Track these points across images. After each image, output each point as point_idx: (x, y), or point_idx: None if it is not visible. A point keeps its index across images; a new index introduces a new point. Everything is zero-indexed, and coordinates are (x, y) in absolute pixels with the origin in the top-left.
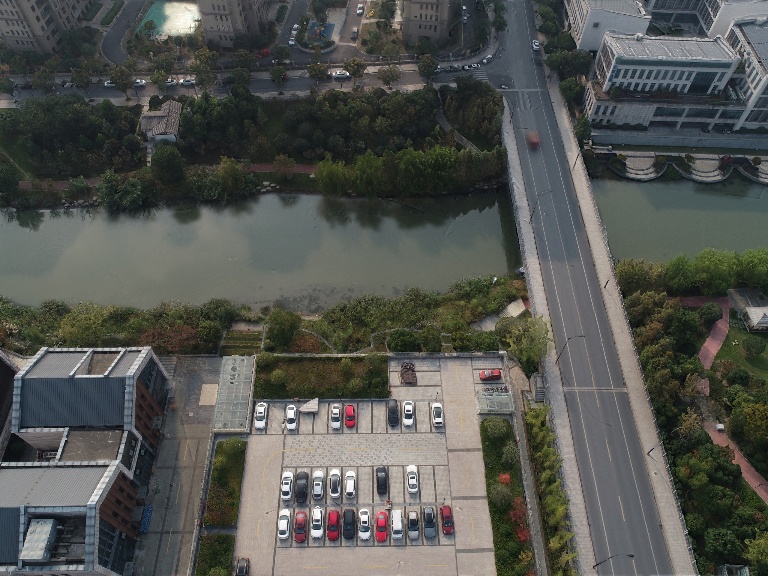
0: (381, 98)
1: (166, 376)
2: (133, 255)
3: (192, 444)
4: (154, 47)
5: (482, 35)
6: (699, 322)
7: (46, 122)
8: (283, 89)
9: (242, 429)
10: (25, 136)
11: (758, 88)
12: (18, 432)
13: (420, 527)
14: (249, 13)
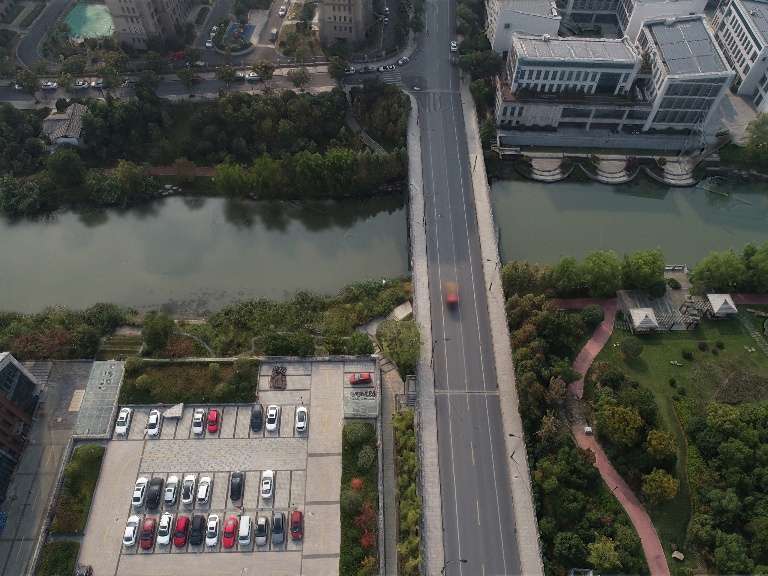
0: (289, 100)
1: (34, 382)
2: (25, 259)
3: (56, 450)
4: (70, 50)
5: (399, 36)
6: (578, 324)
7: None
8: (195, 91)
9: (102, 435)
10: None
11: (661, 89)
12: None
13: (269, 533)
14: (162, 15)
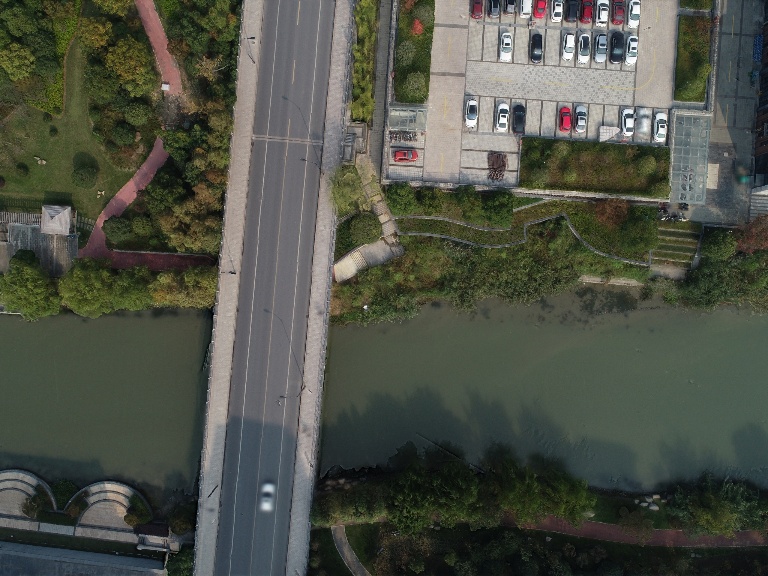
0: None
1: (766, 187)
2: None
3: (722, 121)
4: None
5: None
6: (139, 208)
7: None
8: None
9: (680, 112)
10: None
11: None
12: None
13: (503, 3)
14: None
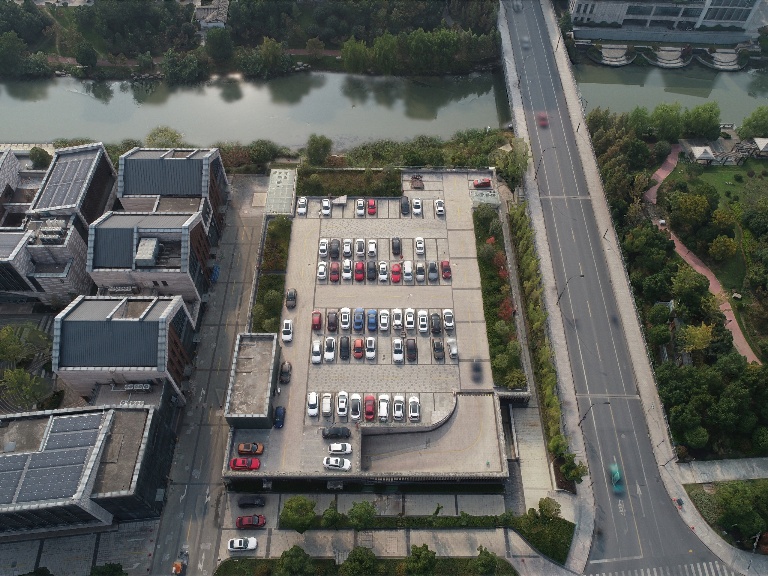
0: None
1: (227, 182)
2: (192, 112)
3: (248, 230)
4: None
5: None
6: (651, 153)
7: (118, 10)
8: None
9: (288, 213)
10: (101, 22)
11: None
12: (122, 197)
13: (425, 275)
14: None
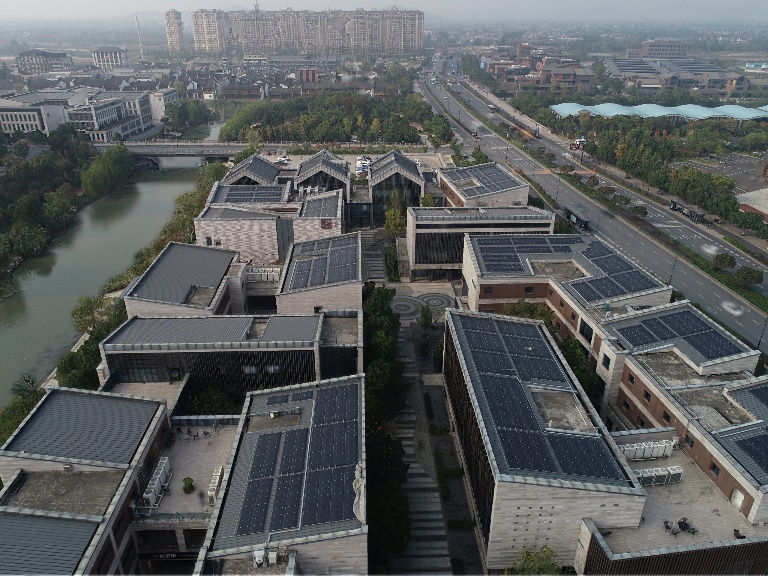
0: None
1: None
2: (105, 241)
3: None
4: None
5: None
6: None
7: None
8: None
9: None
10: None
11: (138, 105)
12: None
13: None
14: None
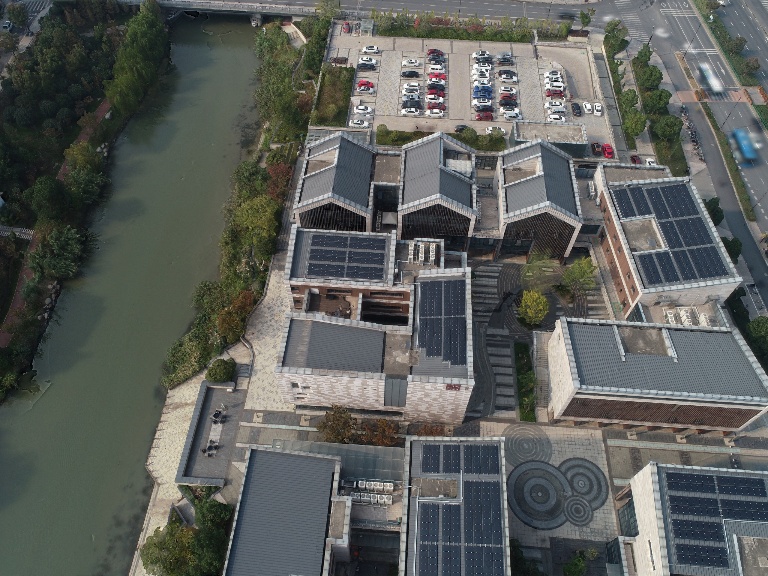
0: None
1: None
2: (153, 244)
3: None
4: None
5: None
6: None
7: None
8: None
9: (368, 132)
10: None
11: None
12: None
13: None
14: None
